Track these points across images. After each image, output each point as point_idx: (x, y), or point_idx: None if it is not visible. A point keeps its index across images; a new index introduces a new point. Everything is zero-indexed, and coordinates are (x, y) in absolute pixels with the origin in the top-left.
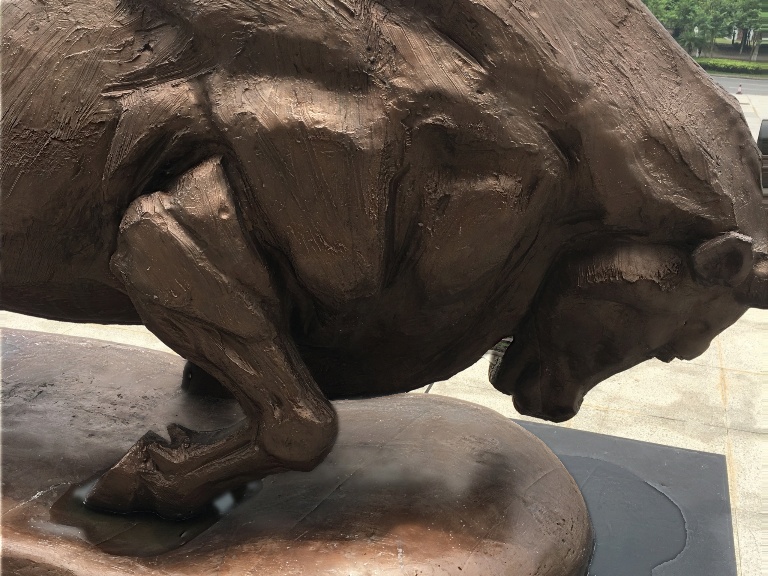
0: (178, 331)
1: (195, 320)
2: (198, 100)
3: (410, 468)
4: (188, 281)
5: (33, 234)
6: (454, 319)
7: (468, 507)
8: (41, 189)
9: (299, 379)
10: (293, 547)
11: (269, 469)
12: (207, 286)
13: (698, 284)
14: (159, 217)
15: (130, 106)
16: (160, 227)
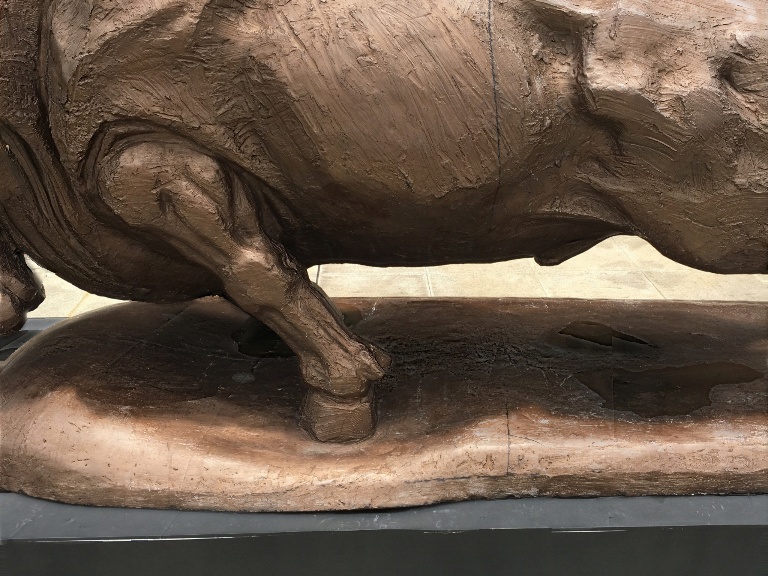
0: None
1: None
2: None
3: (117, 324)
4: None
5: None
6: None
7: None
8: None
9: None
10: None
11: None
12: None
13: None
14: None
15: None
16: None
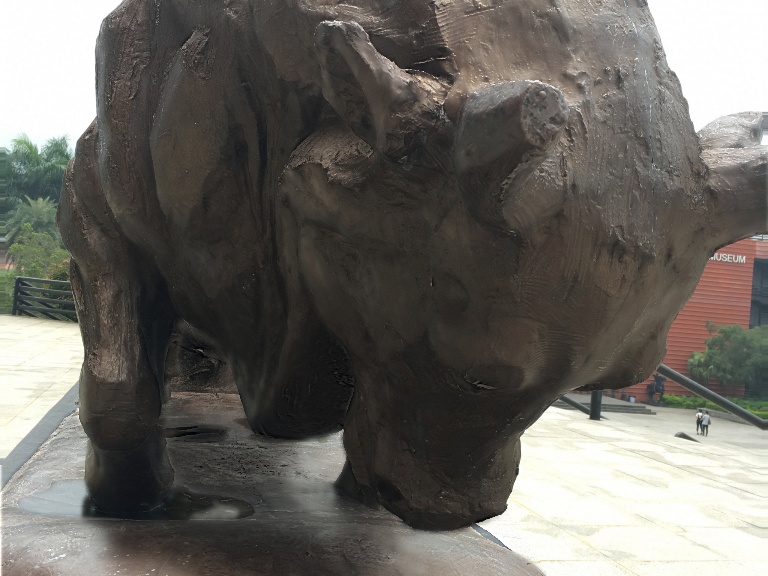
0: None
1: None
2: None
3: None
4: None
5: None
6: (234, 274)
7: (187, 565)
8: None
9: (113, 328)
10: (45, 525)
11: None
12: (66, 206)
13: (406, 180)
14: None
15: None
16: None
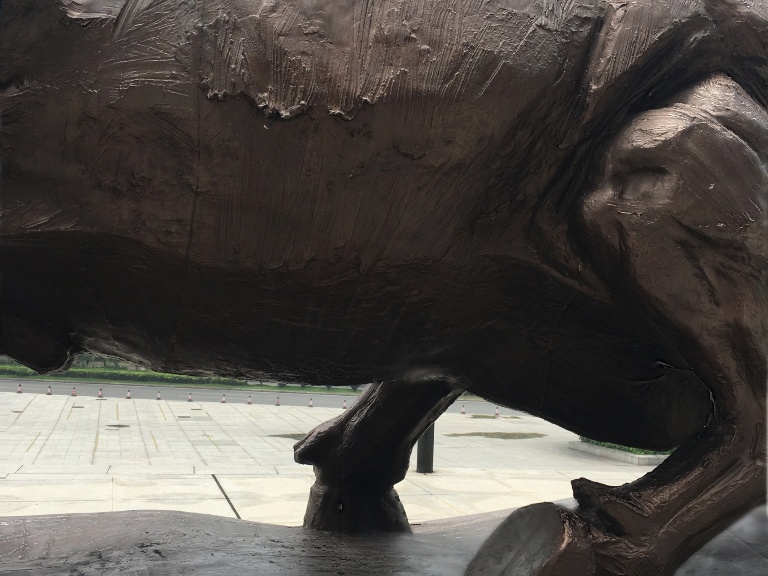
0: (709, 287)
1: (750, 262)
2: (705, 4)
3: None
4: (761, 201)
5: (473, 168)
6: None
7: None
8: (521, 91)
9: None
10: None
11: (762, 496)
12: None
13: None
14: (712, 123)
15: (627, 1)
16: (721, 133)
